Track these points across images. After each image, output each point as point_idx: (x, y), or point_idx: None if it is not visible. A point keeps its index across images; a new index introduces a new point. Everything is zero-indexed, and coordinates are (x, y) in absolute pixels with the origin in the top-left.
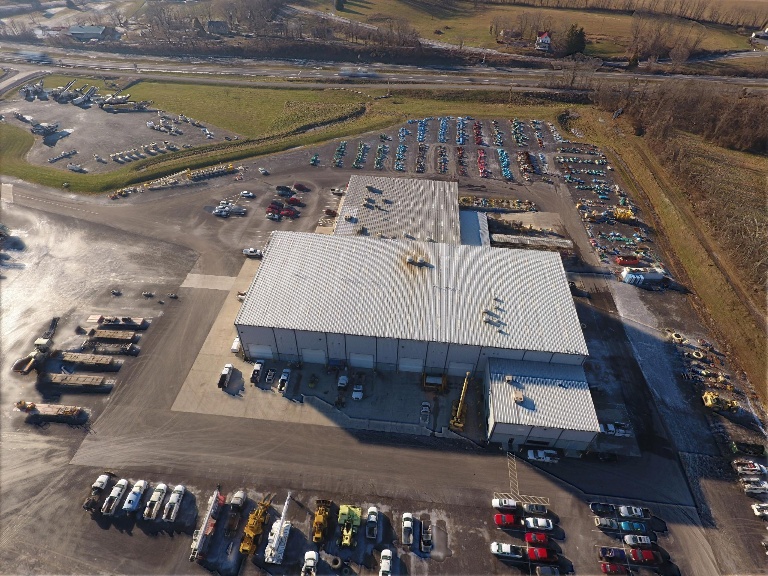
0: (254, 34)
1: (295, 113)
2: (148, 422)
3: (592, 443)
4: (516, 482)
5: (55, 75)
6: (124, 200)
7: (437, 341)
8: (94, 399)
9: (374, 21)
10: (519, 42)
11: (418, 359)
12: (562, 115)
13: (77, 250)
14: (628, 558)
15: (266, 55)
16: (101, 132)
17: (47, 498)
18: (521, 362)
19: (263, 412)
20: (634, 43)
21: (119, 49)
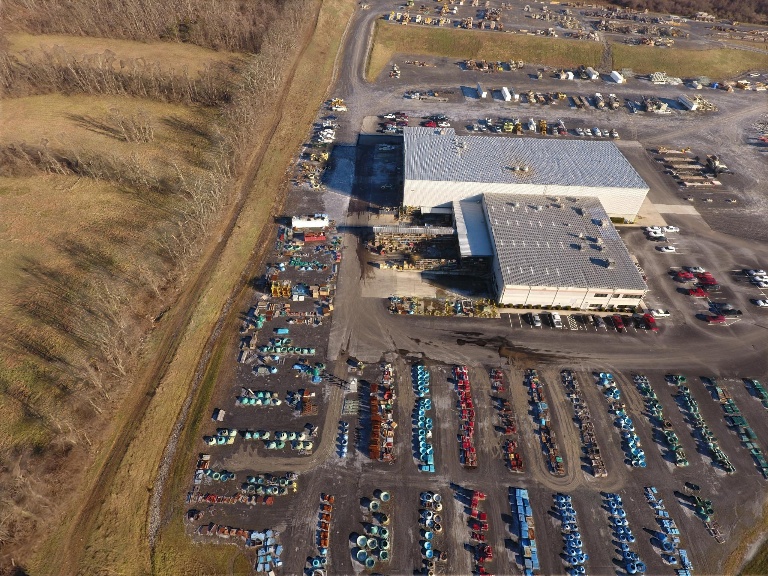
0: None
1: None
2: (621, 150)
3: None
4: None
5: None
6: None
7: None
8: None
9: None
10: None
11: None
12: None
13: None
14: None
15: None
16: None
17: None
18: None
19: None
20: None
21: None
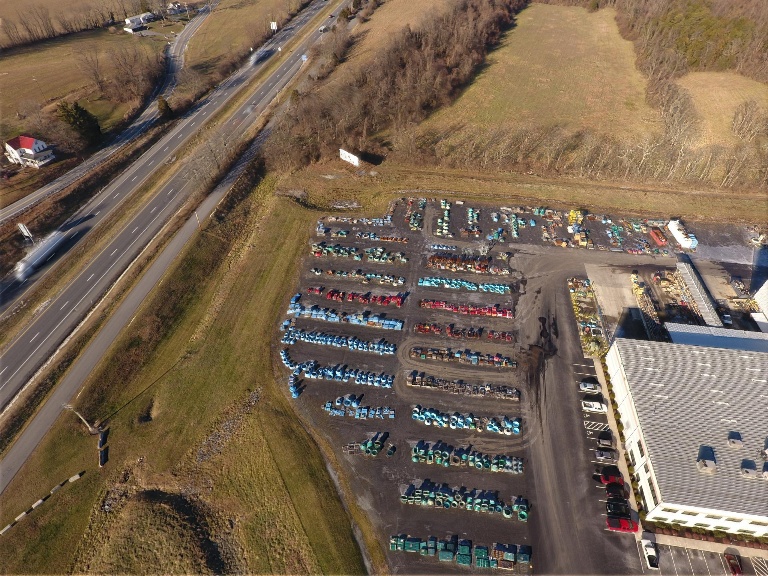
0: None
1: None
2: None
3: None
4: None
5: None
6: None
7: None
8: None
9: None
10: None
11: None
12: (299, 203)
13: None
14: None
15: None
16: None
17: None
18: None
19: None
20: (117, 89)
21: None
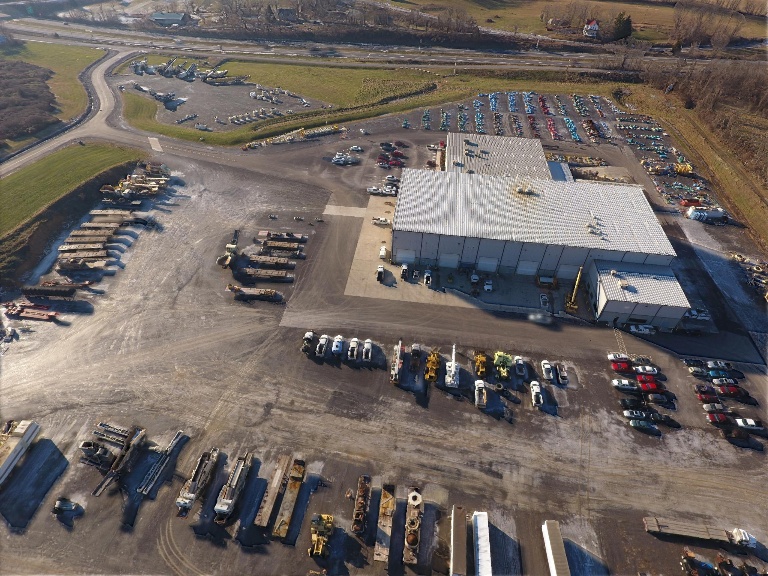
0: (321, 21)
1: (374, 88)
2: (329, 302)
3: (680, 323)
4: (624, 346)
5: (152, 54)
6: (254, 151)
7: (555, 244)
8: (282, 286)
9: (428, 11)
10: (567, 30)
11: (535, 262)
12: (616, 92)
13: (229, 187)
14: (717, 393)
15: (335, 39)
16: (211, 100)
17: (270, 346)
18: (621, 263)
19: (416, 298)
20: (676, 31)
21: (199, 33)
